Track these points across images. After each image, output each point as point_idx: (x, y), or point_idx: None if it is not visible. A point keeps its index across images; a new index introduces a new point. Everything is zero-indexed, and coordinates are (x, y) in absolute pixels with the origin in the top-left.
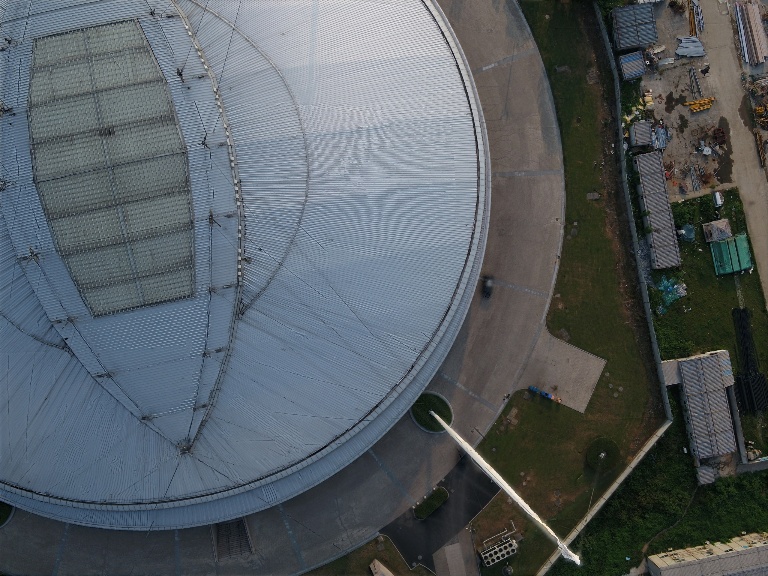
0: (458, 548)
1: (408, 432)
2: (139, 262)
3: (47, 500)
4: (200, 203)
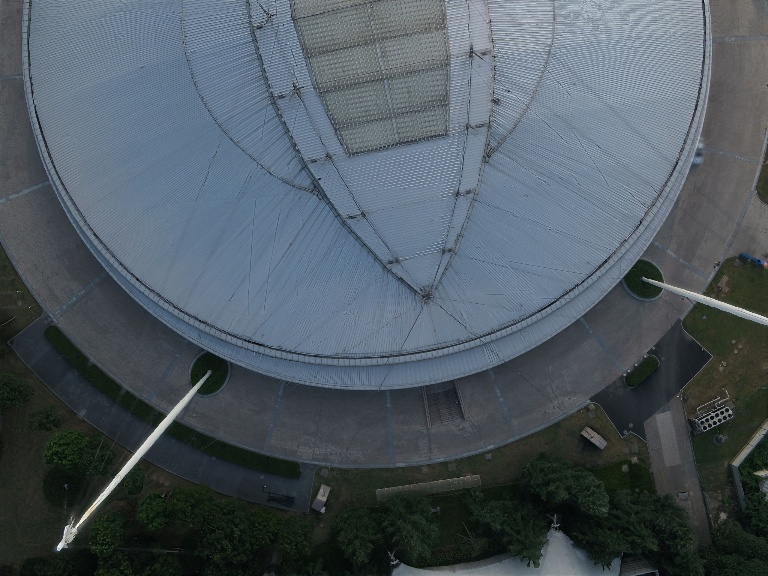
0: (669, 416)
1: (619, 299)
2: (396, 99)
3: (279, 355)
4: (456, 40)
